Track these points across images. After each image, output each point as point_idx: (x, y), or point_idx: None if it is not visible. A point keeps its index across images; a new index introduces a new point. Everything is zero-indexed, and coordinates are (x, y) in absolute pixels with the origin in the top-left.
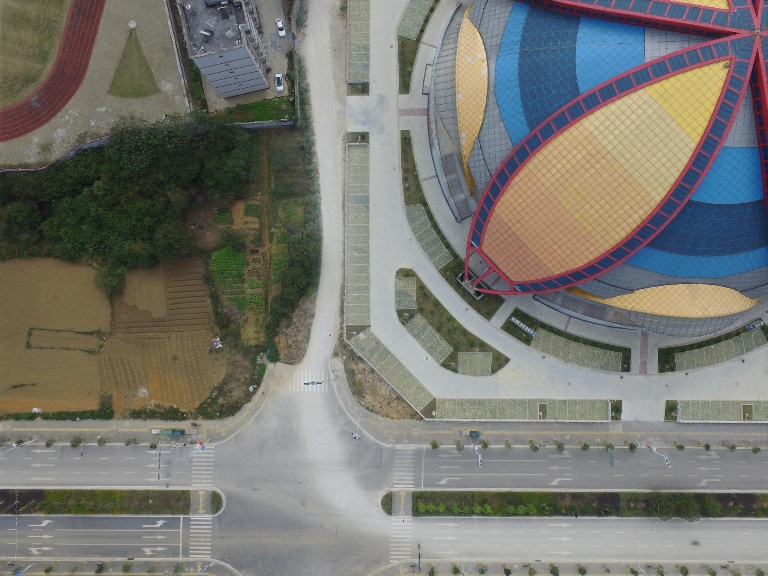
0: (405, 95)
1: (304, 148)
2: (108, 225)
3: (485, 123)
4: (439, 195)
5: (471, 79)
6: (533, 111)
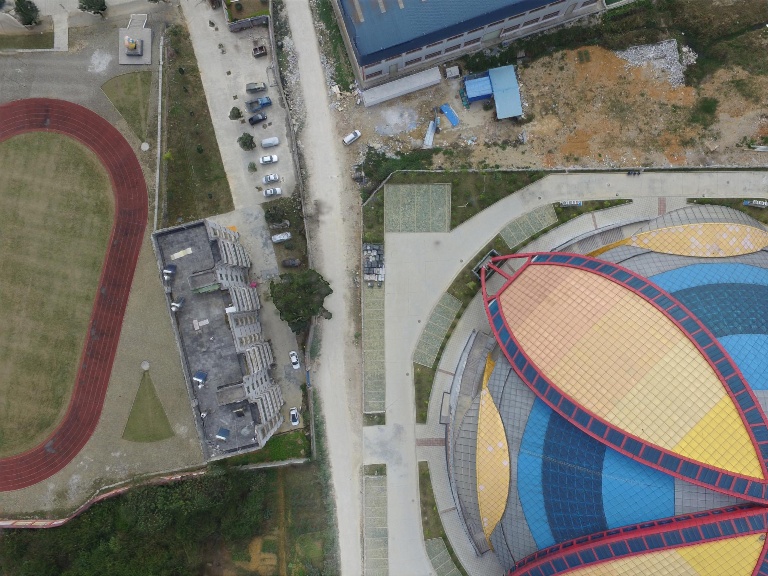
0: (422, 424)
1: (321, 484)
2: (125, 575)
3: (507, 512)
4: (459, 527)
5: (492, 471)
6: (558, 524)
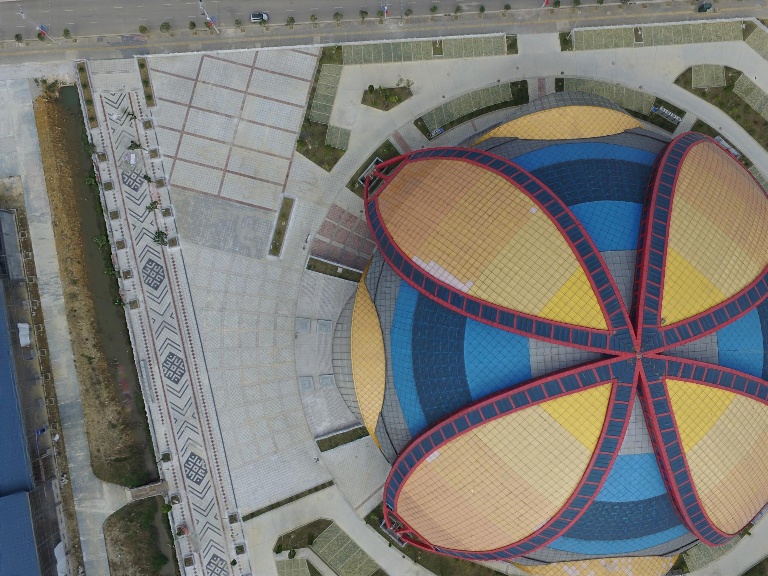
0: None
1: None
2: None
3: None
4: None
5: None
6: None
